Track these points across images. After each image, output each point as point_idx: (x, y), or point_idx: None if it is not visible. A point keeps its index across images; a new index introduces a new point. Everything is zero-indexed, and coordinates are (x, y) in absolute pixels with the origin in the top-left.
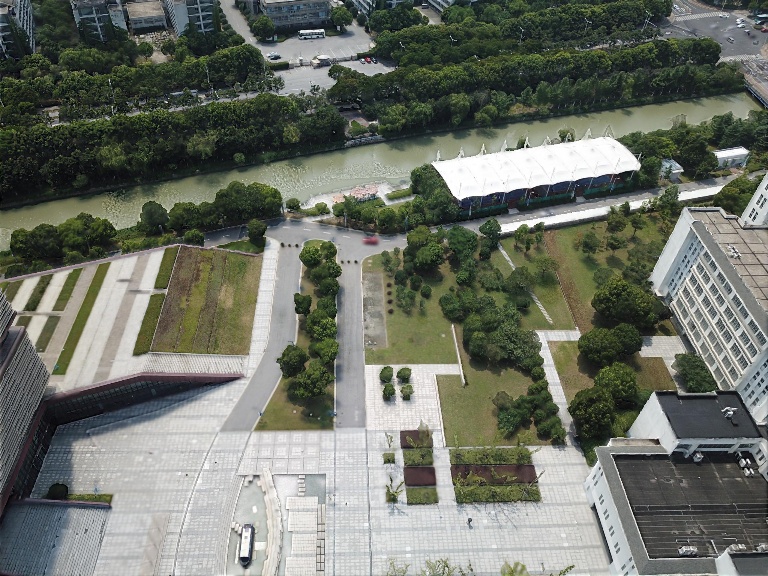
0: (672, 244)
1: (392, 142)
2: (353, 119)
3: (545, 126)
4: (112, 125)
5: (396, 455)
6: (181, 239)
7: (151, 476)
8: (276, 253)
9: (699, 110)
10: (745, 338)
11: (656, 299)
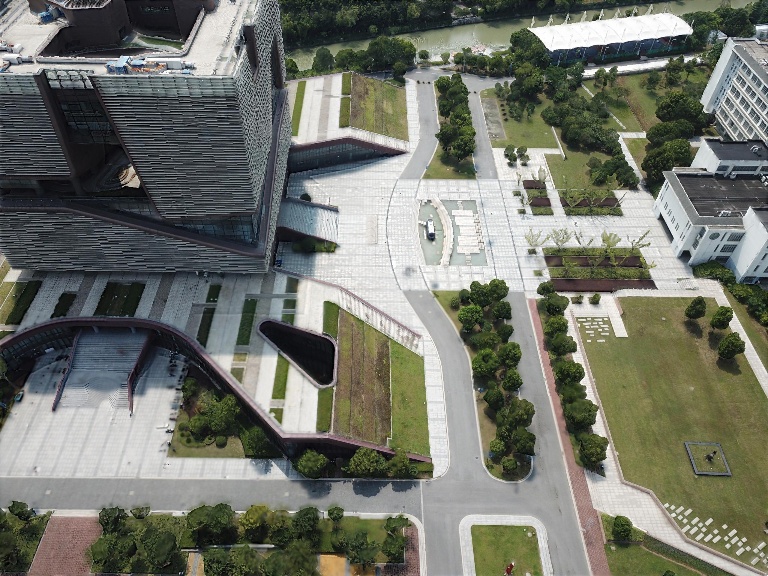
0: (718, 69)
1: (489, 22)
2: (456, 6)
3: (612, 13)
4: (280, 0)
5: (521, 192)
6: None
7: (360, 198)
8: (415, 87)
9: (742, 3)
10: None
11: (704, 114)
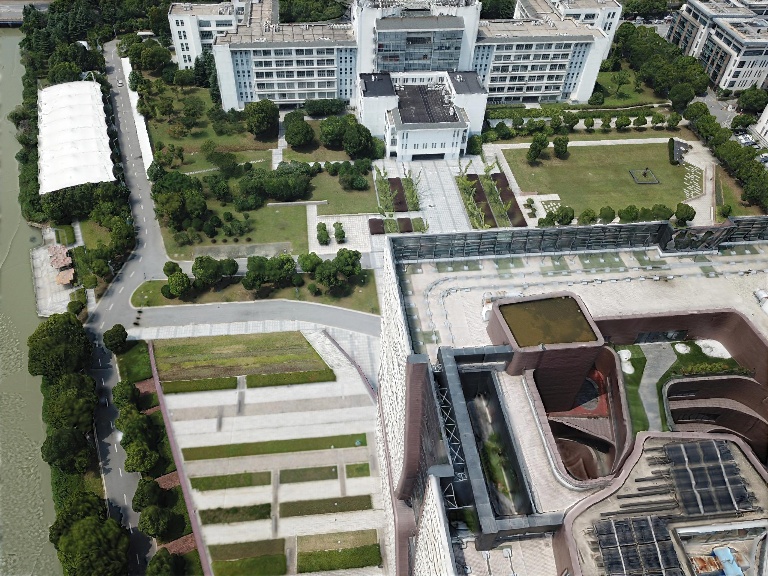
0: (224, 74)
1: None
2: None
3: None
4: None
5: None
6: (98, 431)
7: None
8: (149, 329)
9: None
10: (321, 63)
11: None
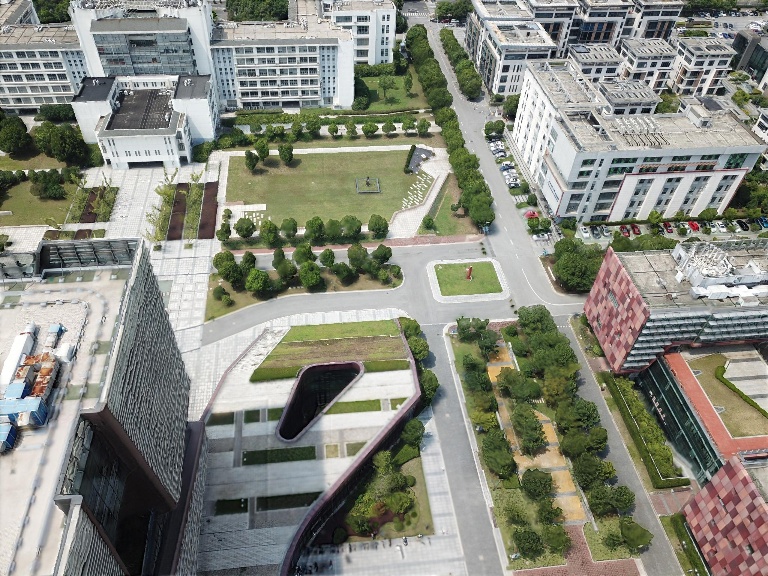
0: None
1: None
2: None
3: None
4: None
5: None
6: None
7: None
8: None
9: None
10: (48, 66)
11: None
